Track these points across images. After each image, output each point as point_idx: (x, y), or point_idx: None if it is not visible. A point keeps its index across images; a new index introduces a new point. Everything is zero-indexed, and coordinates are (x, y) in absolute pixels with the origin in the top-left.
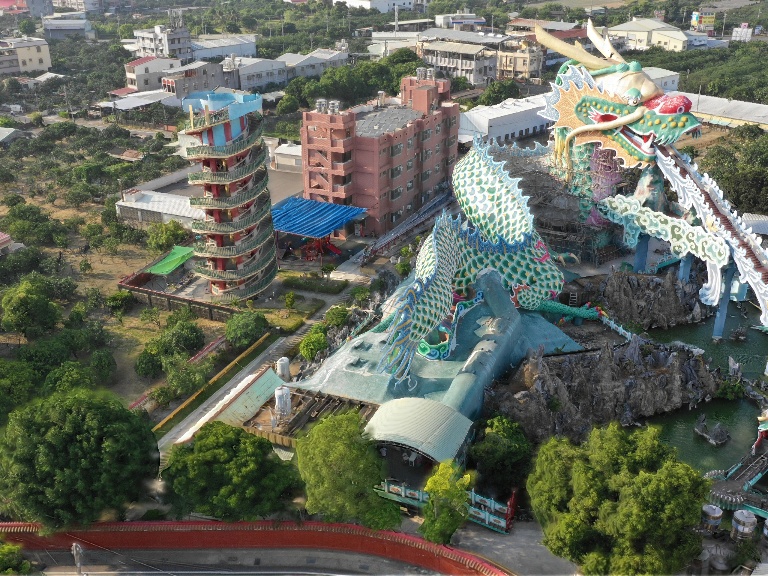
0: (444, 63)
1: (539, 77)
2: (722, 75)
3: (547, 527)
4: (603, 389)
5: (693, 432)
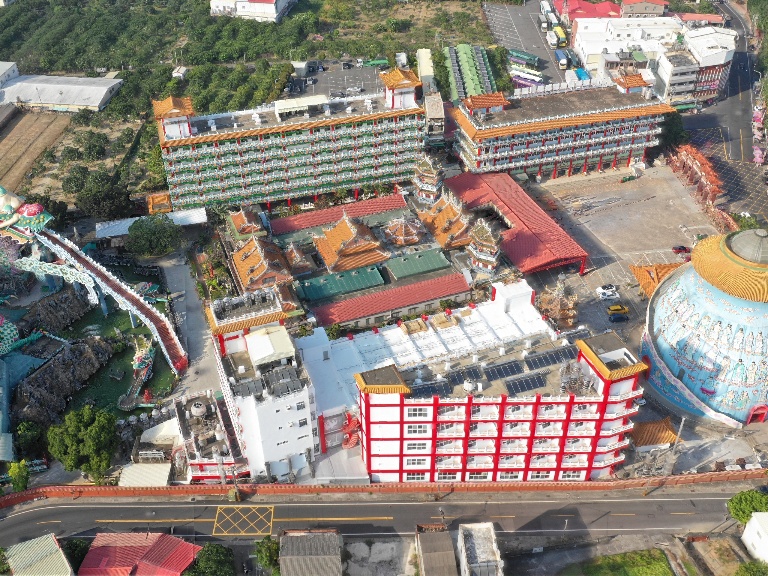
0: None
1: None
2: (47, 44)
3: (64, 462)
4: (62, 379)
5: (110, 377)
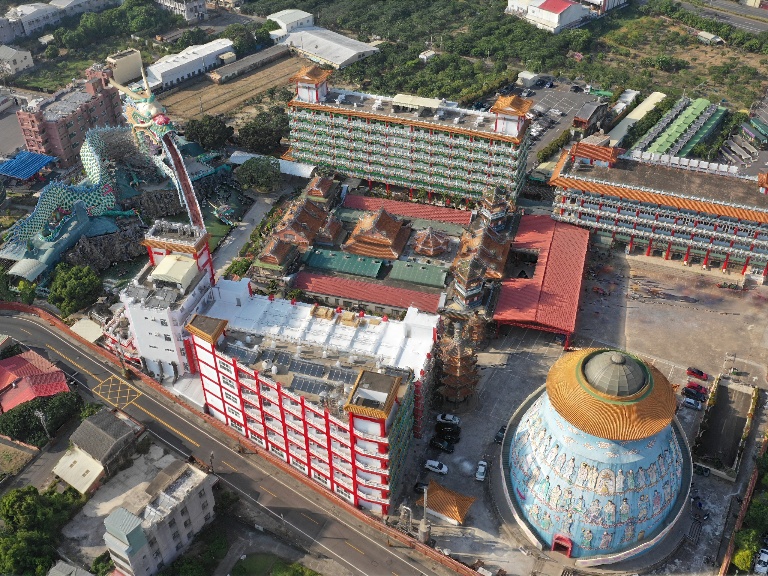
0: (168, 3)
1: (239, 7)
2: (355, 6)
3: None
4: (117, 248)
5: None
